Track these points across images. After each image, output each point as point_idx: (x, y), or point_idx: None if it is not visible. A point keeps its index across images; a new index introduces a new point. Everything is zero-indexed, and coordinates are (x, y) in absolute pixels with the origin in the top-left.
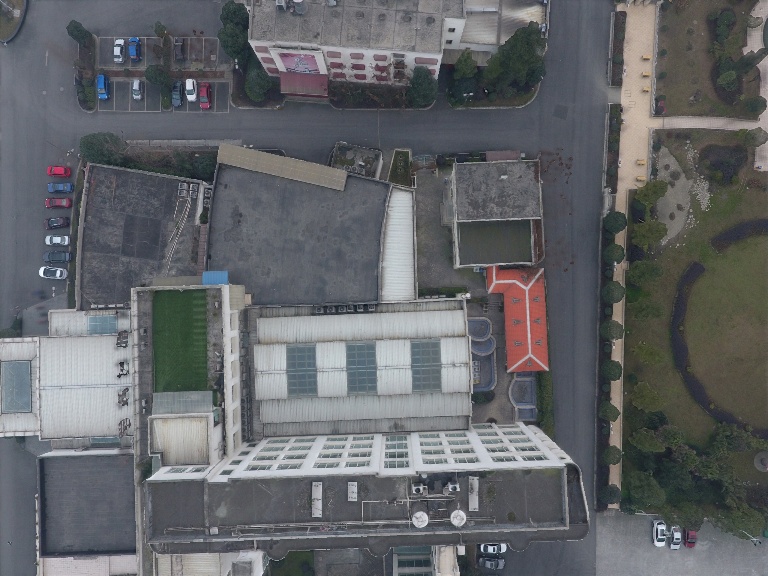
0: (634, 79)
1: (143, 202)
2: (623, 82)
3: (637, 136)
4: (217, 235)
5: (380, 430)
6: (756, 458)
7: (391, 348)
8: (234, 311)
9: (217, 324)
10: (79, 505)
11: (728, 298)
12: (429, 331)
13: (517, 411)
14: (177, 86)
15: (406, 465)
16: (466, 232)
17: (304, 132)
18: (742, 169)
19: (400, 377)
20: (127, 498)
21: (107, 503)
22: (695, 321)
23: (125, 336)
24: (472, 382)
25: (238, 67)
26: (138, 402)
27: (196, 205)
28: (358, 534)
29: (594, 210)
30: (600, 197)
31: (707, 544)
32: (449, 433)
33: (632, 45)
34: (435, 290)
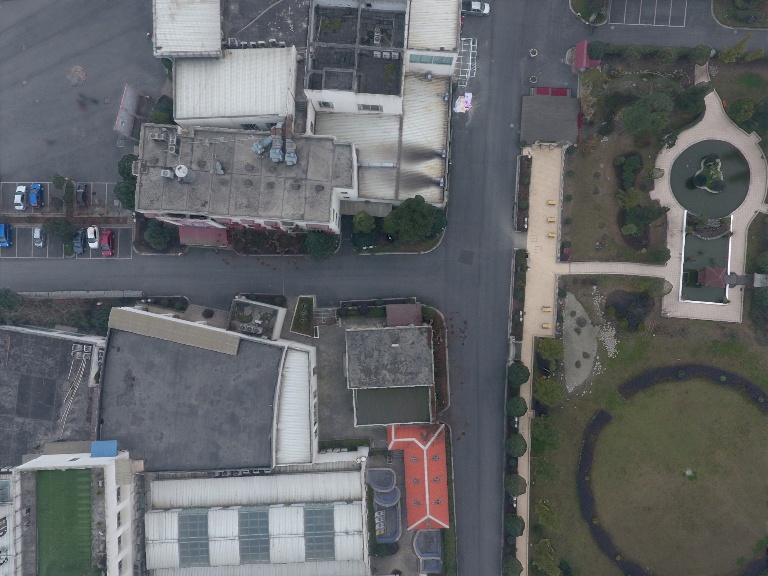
0: (540, 224)
1: (38, 362)
2: (529, 227)
3: (543, 282)
4: (109, 399)
5: None
6: None
7: (284, 516)
8: None
9: (102, 502)
10: None
11: (635, 446)
12: (325, 494)
13: (422, 563)
14: (79, 233)
15: None
16: (363, 391)
17: (208, 278)
18: (649, 315)
19: (293, 545)
20: None
21: None
22: (602, 470)
23: (3, 524)
24: (365, 551)
25: None
26: None
27: None
28: None
29: (500, 357)
30: (506, 344)
31: None
32: None
33: (538, 189)
34: (337, 443)
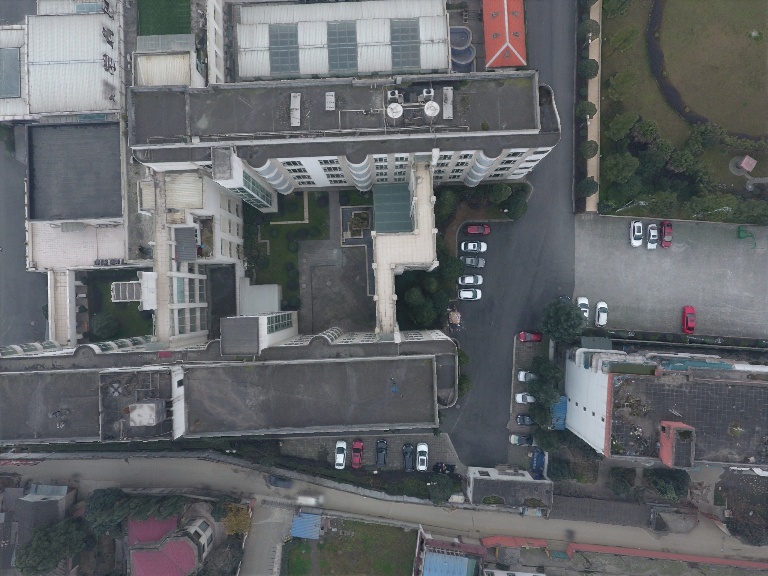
0: None
1: None
2: None
3: None
4: None
5: None
6: (731, 162)
7: (371, 26)
8: None
9: None
10: (67, 175)
11: (703, 8)
12: None
13: None
14: None
15: None
16: None
17: None
18: None
19: (380, 54)
20: (114, 168)
21: (94, 173)
22: (671, 31)
23: None
24: (450, 57)
25: None
26: (123, 59)
27: None
28: (335, 137)
29: None
30: None
31: (683, 246)
32: None
33: None
34: None
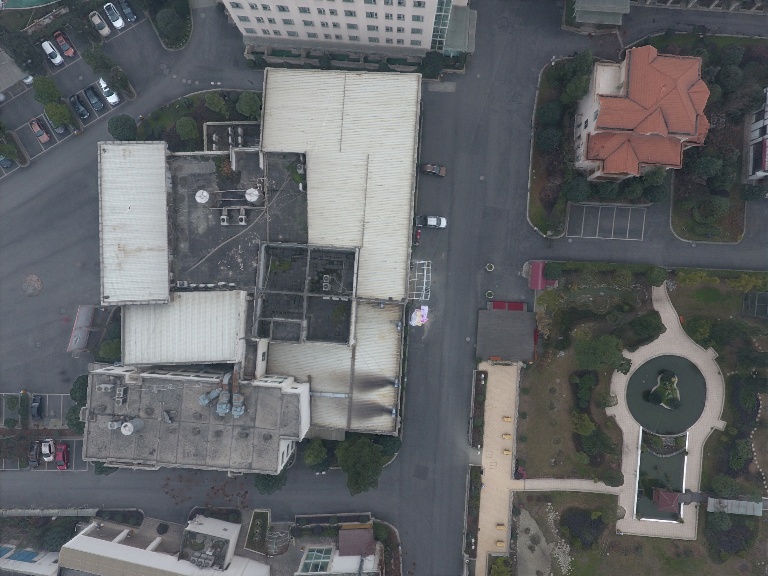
0: (495, 439)
1: None
2: (484, 442)
3: (498, 498)
4: None
5: None
6: None
7: None
8: None
9: None
10: None
11: None
12: None
13: None
14: (34, 446)
15: None
16: None
17: (163, 491)
18: (603, 532)
19: None
20: None
21: None
22: None
23: None
24: None
25: None
26: None
27: None
28: None
29: (454, 573)
30: (460, 560)
31: None
32: None
33: (494, 404)
34: None
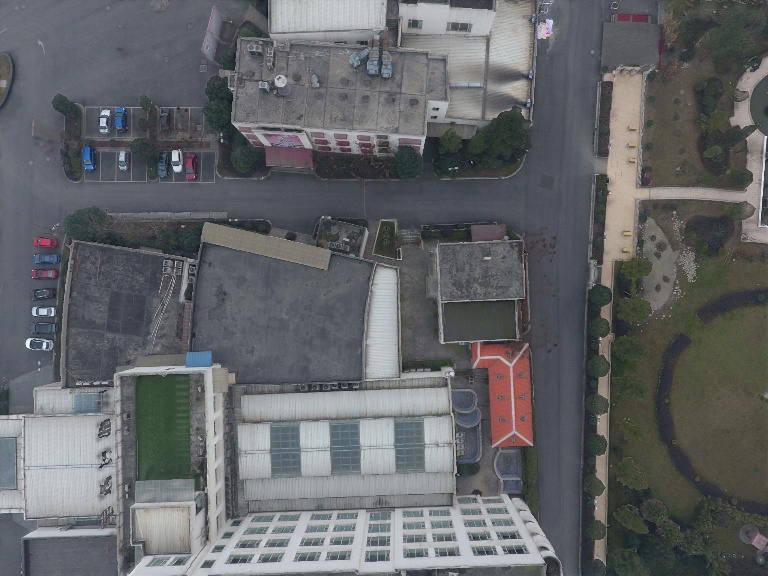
0: (620, 149)
1: (128, 278)
2: (609, 152)
3: (623, 207)
4: (201, 313)
5: (364, 506)
6: (742, 530)
7: (375, 428)
8: (218, 392)
9: (200, 408)
10: None
11: (714, 370)
12: (413, 409)
13: (502, 483)
14: (163, 157)
15: (387, 558)
16: (450, 309)
17: (290, 202)
18: (729, 240)
19: (384, 457)
20: None
21: None
22: (681, 393)
23: (107, 424)
24: (455, 462)
25: (223, 139)
26: (121, 487)
27: (181, 281)
28: None
29: (580, 281)
30: (586, 268)
31: None
32: (433, 510)
33: (618, 115)
34: (420, 363)
